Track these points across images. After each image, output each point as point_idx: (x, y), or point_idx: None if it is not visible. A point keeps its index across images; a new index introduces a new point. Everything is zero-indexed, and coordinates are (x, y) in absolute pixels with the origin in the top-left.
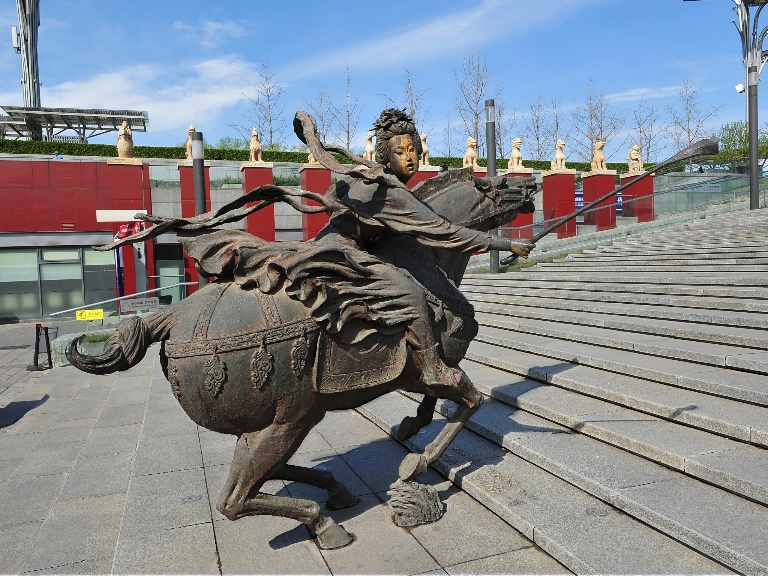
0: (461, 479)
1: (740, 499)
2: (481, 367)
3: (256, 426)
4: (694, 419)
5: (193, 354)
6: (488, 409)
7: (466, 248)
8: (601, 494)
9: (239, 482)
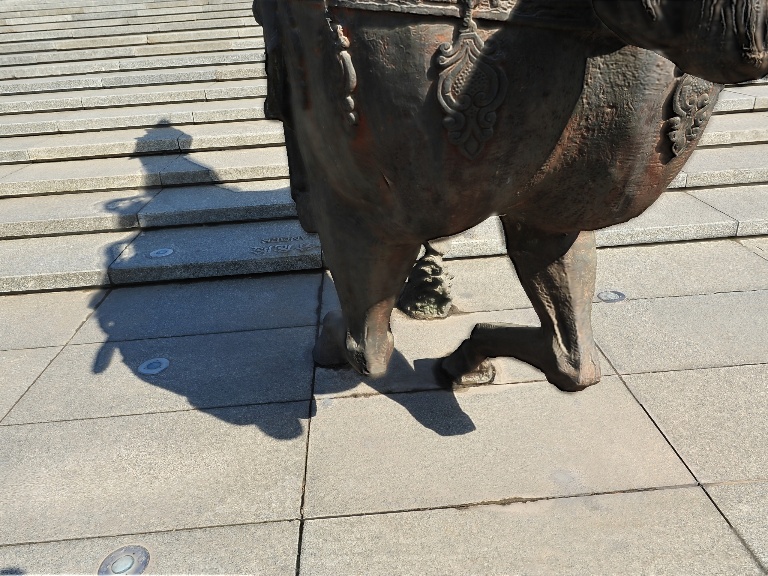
0: None
1: None
2: (19, 167)
3: None
4: None
5: None
6: (187, 196)
7: None
8: None
9: None
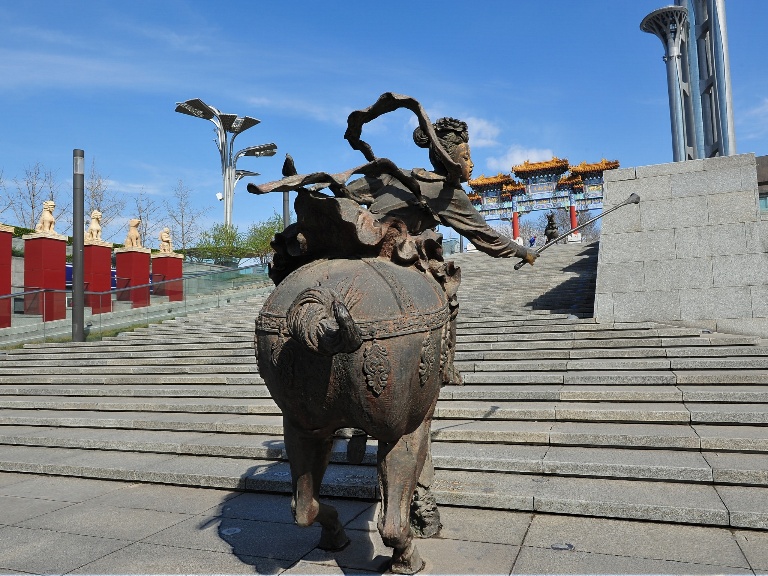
0: None
1: None
2: (239, 416)
3: (416, 424)
4: (508, 413)
5: (412, 331)
6: None
7: (502, 252)
8: (529, 468)
9: (405, 496)
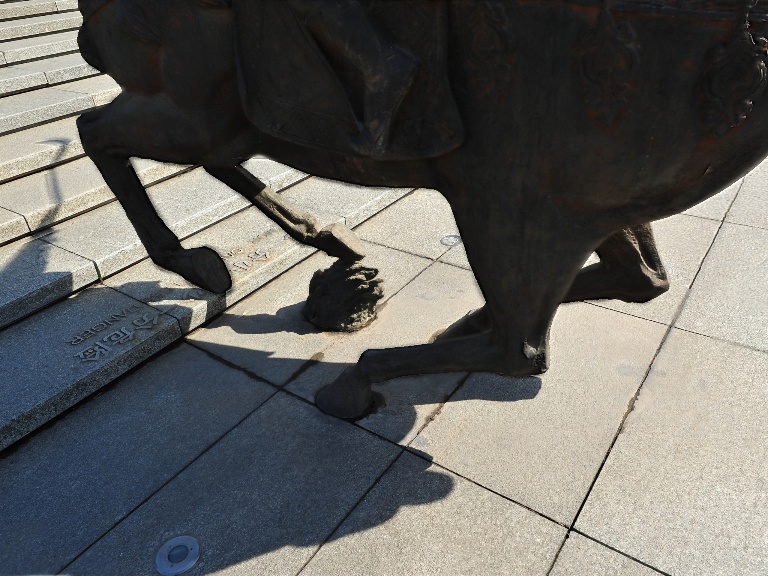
0: (224, 295)
1: None
2: None
3: None
4: None
5: None
6: None
7: None
8: None
9: None
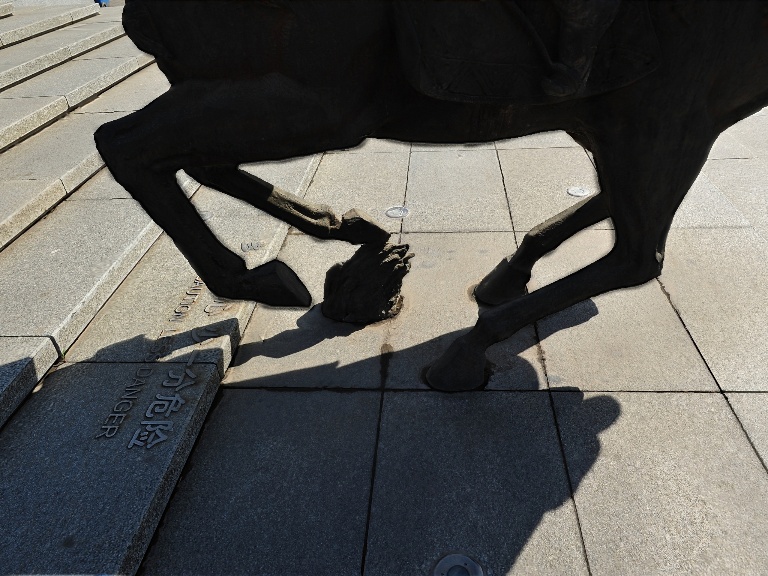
0: None
1: (105, 170)
2: None
3: None
4: None
5: None
6: None
7: None
8: None
9: None
